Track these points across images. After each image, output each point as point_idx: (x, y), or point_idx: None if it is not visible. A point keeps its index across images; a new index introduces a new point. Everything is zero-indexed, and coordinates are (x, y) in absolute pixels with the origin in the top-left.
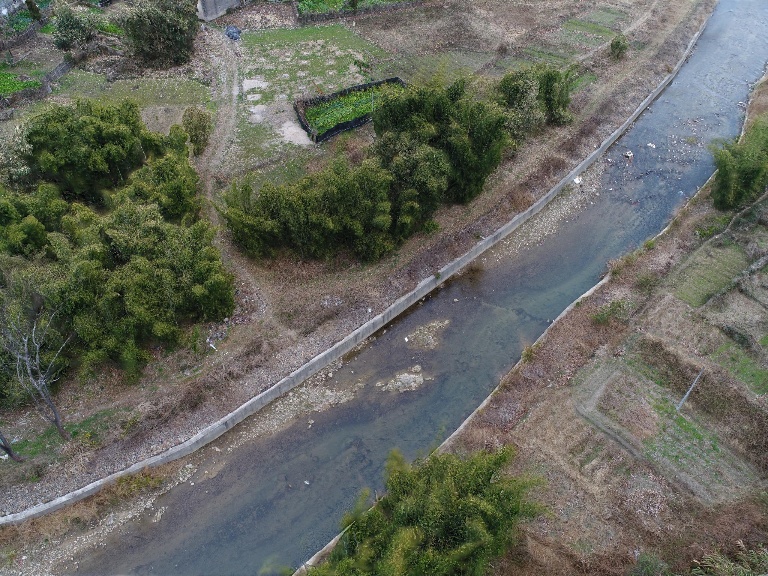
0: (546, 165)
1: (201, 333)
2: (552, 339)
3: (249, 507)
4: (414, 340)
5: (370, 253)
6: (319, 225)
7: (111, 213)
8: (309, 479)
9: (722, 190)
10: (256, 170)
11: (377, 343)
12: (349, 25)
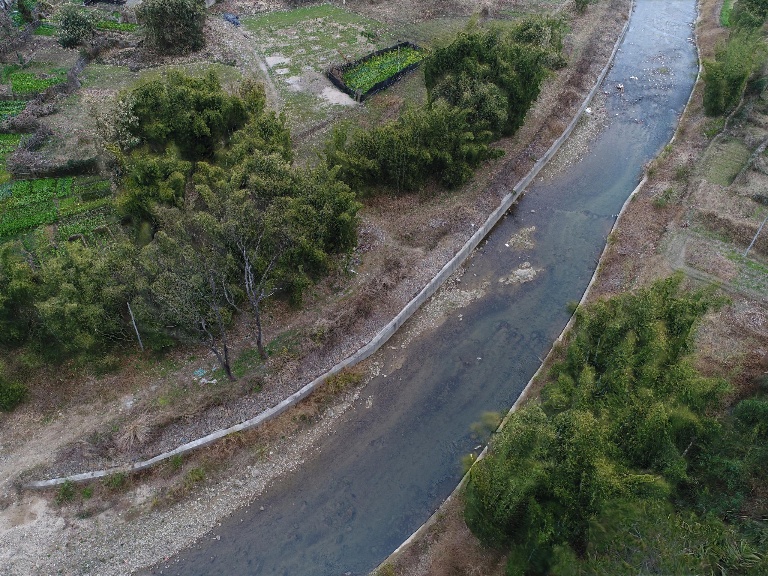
0: (565, 98)
1: (337, 262)
2: (625, 226)
3: (441, 384)
4: (514, 244)
5: (457, 180)
6: (416, 158)
7: (232, 168)
8: (480, 356)
9: (714, 99)
10: (317, 130)
11: (485, 251)
12: (337, 4)
